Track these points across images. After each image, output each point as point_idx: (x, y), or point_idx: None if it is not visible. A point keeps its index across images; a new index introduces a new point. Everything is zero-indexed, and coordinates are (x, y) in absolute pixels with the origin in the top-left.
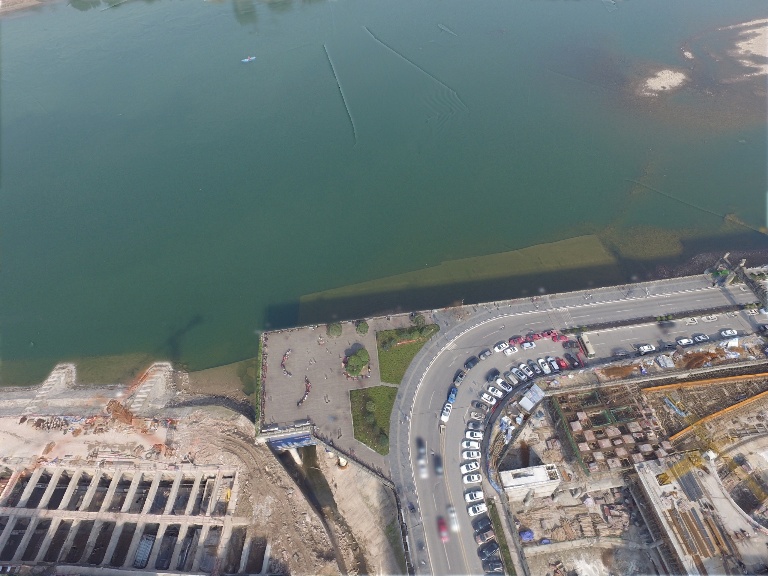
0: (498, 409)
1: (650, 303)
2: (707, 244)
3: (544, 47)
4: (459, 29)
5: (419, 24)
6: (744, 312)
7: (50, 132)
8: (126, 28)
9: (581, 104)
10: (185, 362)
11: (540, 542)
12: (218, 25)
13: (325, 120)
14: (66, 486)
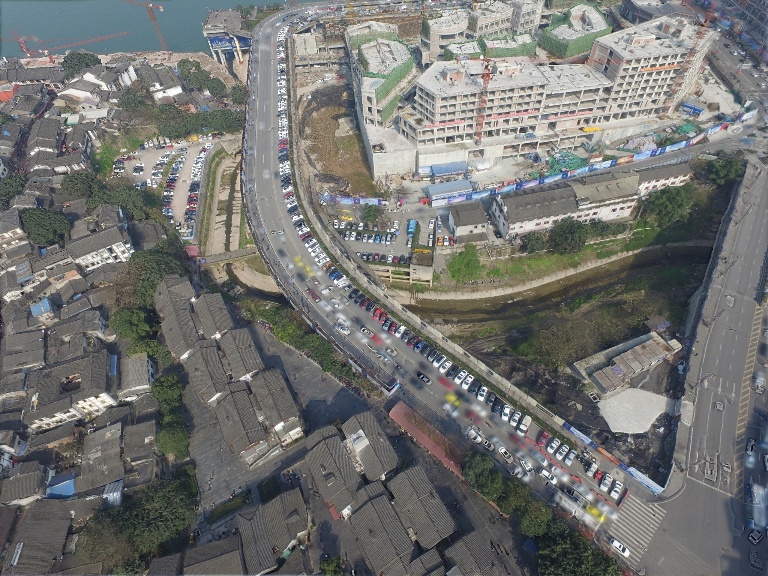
0: None
1: (380, 2)
2: None
3: None
4: None
5: None
6: (417, 2)
7: None
8: None
9: None
10: None
11: None
12: None
13: None
14: None
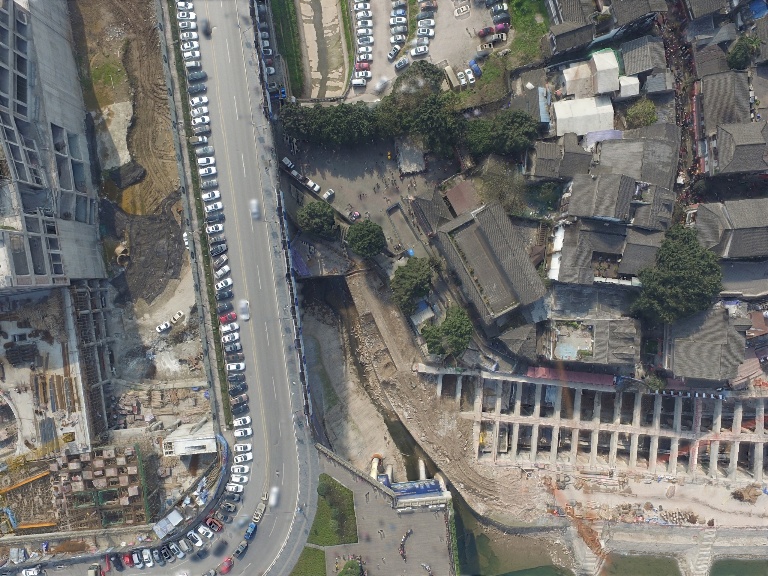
0: (206, 513)
1: None
2: None
3: None
4: None
5: None
6: None
7: None
8: None
9: None
10: None
11: (200, 389)
12: None
13: None
14: (646, 450)
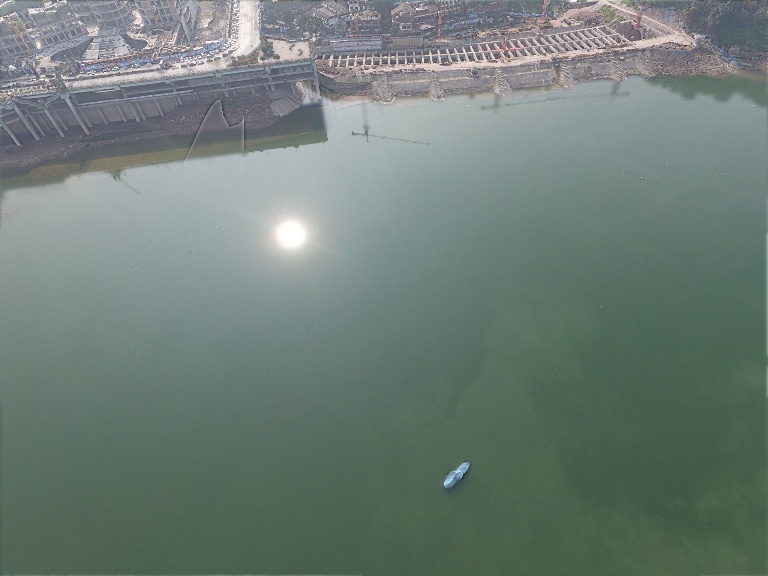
0: None
1: None
2: (12, 173)
3: None
4: None
5: None
6: None
7: (662, 263)
8: None
9: None
10: (375, 105)
11: None
12: None
13: (294, 311)
14: None
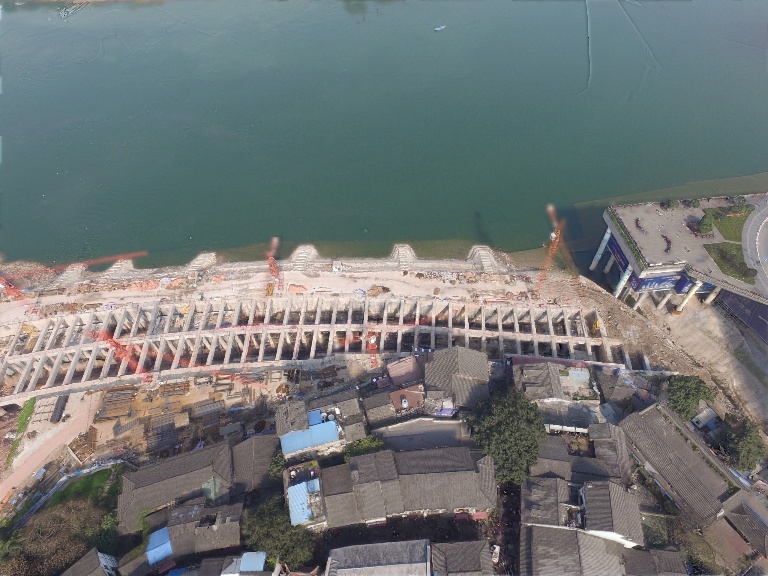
0: None
1: None
2: None
3: (710, 20)
4: (622, 5)
5: (582, 1)
6: None
7: (294, 83)
8: (315, 4)
9: (763, 66)
10: (499, 246)
11: None
12: (397, 1)
13: (528, 77)
14: None
